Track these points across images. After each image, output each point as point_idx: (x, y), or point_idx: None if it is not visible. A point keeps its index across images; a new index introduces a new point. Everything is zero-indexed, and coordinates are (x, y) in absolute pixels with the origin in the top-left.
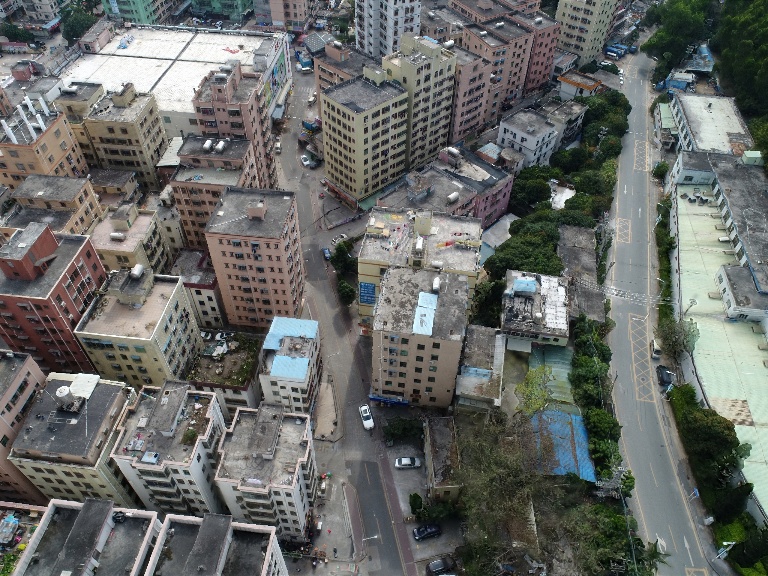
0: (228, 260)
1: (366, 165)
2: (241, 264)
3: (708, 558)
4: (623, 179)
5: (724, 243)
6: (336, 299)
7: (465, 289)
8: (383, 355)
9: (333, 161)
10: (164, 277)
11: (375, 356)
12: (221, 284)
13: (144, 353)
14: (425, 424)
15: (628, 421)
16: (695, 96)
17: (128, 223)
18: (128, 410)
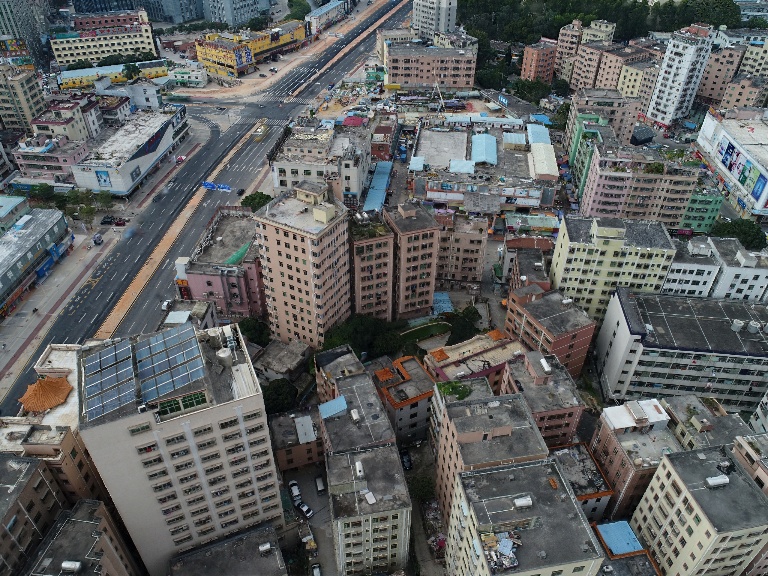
0: None
1: None
2: None
3: None
4: None
5: None
6: None
7: None
8: None
9: None
10: None
11: None
12: None
13: None
14: None
15: None
16: (656, 36)
17: None
18: None
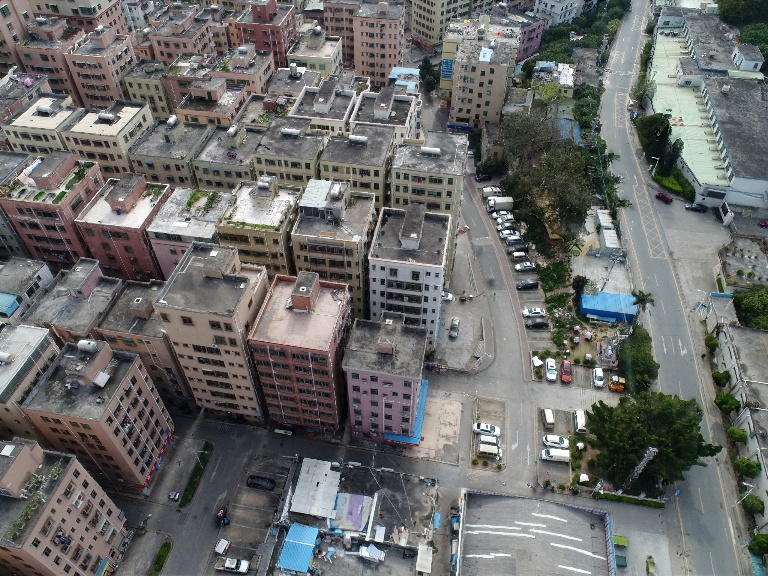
0: (364, 39)
1: (442, 16)
2: (371, 42)
3: (647, 182)
4: (623, 34)
5: (684, 54)
6: (422, 93)
7: (510, 48)
8: (459, 83)
9: (418, 17)
10: (331, 37)
11: (454, 85)
12: (356, 61)
13: (324, 70)
14: (483, 127)
15: (608, 134)
16: None
17: (299, 24)
18: (324, 81)
